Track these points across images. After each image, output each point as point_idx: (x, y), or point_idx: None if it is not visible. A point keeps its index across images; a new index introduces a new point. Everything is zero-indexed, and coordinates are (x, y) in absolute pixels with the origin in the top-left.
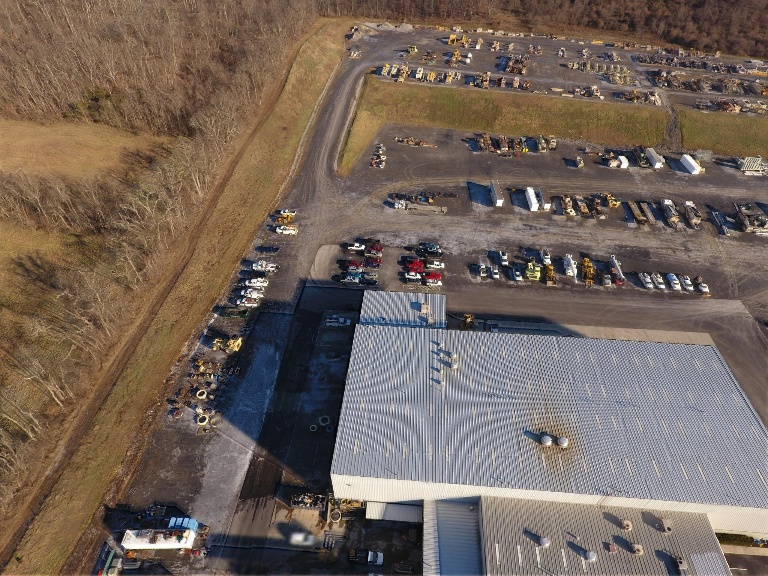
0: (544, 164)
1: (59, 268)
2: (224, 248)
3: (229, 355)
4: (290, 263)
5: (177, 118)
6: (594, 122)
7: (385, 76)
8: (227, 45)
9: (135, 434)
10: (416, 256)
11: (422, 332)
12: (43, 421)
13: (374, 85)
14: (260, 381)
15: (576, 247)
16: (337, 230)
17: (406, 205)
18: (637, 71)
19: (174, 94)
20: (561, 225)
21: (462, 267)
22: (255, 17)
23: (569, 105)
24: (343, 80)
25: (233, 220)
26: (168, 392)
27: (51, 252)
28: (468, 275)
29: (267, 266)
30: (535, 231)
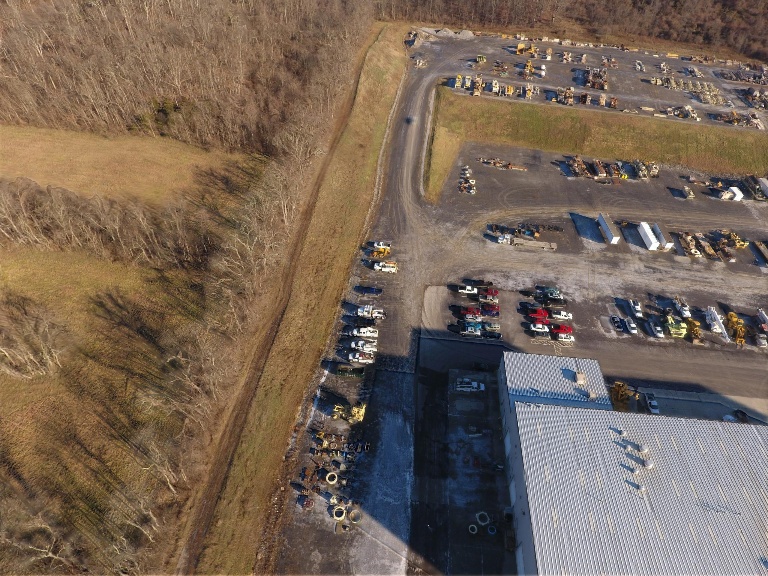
0: (648, 194)
1: (144, 310)
2: (321, 288)
3: (352, 425)
4: (397, 308)
5: (251, 134)
6: (693, 146)
7: (459, 89)
8: (291, 51)
9: (262, 530)
10: (538, 304)
11: (595, 415)
12: (156, 512)
13: (449, 98)
14: (395, 461)
15: (711, 296)
16: (440, 268)
17: (511, 240)
18: (725, 89)
19: (248, 107)
20: (687, 268)
21: (591, 318)
22: (317, 21)
23: (664, 127)
24: (414, 92)
25: (325, 254)
26: (290, 473)
27: (132, 290)
28: (600, 328)
29: (373, 312)
30: (660, 275)
